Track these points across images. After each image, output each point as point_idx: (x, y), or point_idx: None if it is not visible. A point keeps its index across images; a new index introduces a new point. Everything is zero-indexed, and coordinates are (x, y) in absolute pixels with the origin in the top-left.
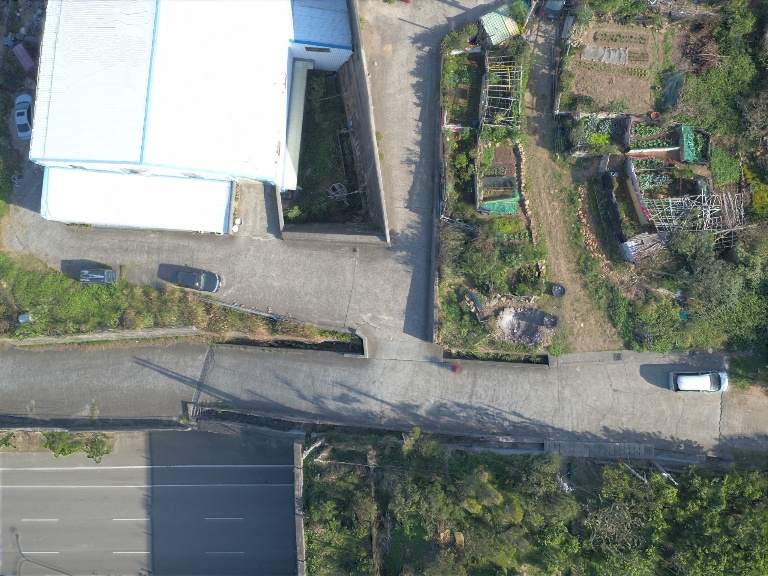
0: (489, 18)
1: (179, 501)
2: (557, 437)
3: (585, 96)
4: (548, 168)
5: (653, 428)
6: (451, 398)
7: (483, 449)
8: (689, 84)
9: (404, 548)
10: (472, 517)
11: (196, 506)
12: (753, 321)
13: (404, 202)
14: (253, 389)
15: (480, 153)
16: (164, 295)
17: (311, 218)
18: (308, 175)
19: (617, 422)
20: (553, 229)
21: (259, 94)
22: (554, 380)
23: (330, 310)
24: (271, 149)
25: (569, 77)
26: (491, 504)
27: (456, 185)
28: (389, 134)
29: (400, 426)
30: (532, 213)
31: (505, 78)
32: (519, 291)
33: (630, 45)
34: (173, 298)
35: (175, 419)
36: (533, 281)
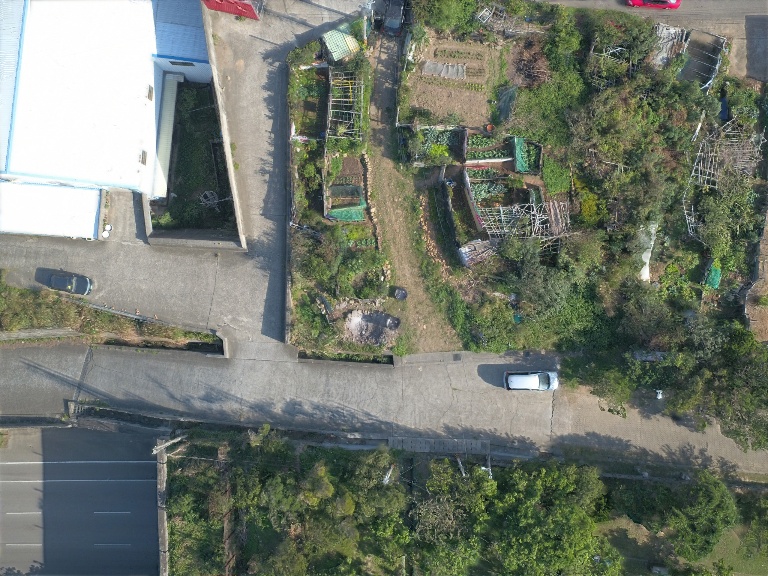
0: (331, 35)
1: (69, 496)
2: (401, 433)
3: (424, 109)
4: (393, 178)
5: (489, 425)
6: (305, 396)
7: (333, 445)
8: (521, 98)
9: (257, 539)
10: (314, 509)
11: (86, 500)
12: (581, 323)
13: (259, 209)
14: (127, 388)
15: (328, 163)
16: (39, 298)
17: (184, 224)
18: (179, 183)
19: (456, 419)
20: (397, 236)
21: (121, 106)
22: (398, 379)
23: (193, 312)
24: (133, 159)
25: (406, 92)
26: (325, 497)
27: (307, 193)
28: (243, 145)
29: (258, 423)
30: (378, 220)
31: (347, 92)
32: (364, 294)
33: (468, 61)
34: (47, 301)
35: (58, 416)
36: (378, 285)
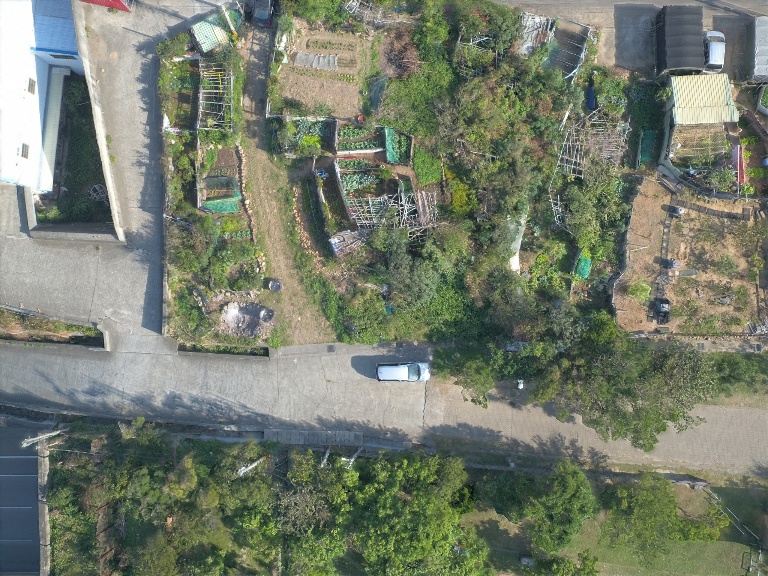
0: (199, 27)
1: None
2: (276, 426)
3: (294, 100)
4: (267, 169)
5: (362, 416)
6: (184, 389)
7: (210, 437)
8: (390, 89)
9: (135, 532)
10: (185, 502)
11: None
12: (451, 314)
13: (137, 202)
14: (16, 382)
15: (203, 155)
16: None
17: (73, 218)
18: (66, 177)
19: (330, 411)
20: (272, 227)
21: None
22: (274, 371)
23: (76, 305)
24: (11, 152)
25: (274, 83)
26: (190, 488)
27: (183, 186)
28: (119, 137)
29: None
30: (253, 212)
31: (217, 84)
32: (237, 286)
33: (340, 52)
34: None
35: None
36: (253, 277)
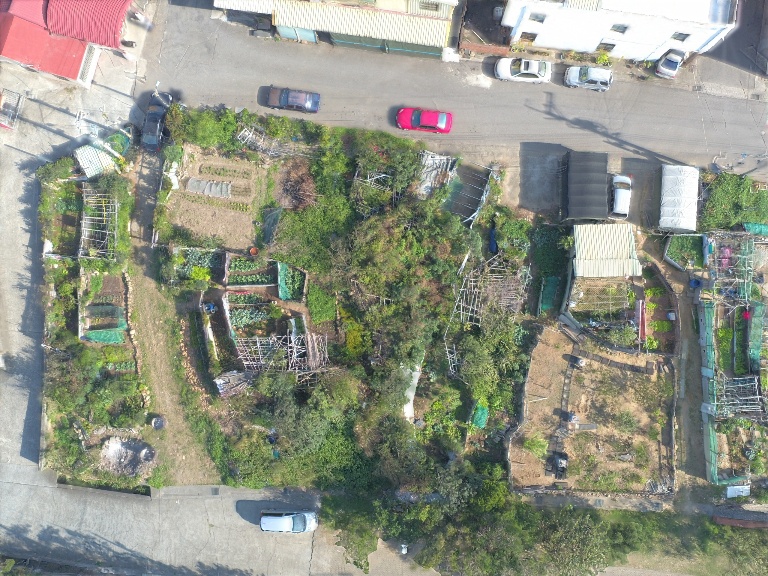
0: (83, 151)
1: None
2: (155, 571)
3: (183, 230)
4: (154, 298)
5: (246, 565)
6: (63, 525)
7: None
8: (283, 222)
9: None
10: None
11: None
12: (341, 462)
13: (18, 326)
14: None
15: (87, 281)
16: None
17: None
18: None
19: (212, 558)
20: (157, 360)
21: None
22: (155, 512)
23: None
24: None
25: (161, 213)
26: None
27: None
28: None
29: (13, 551)
30: (138, 343)
31: (100, 210)
32: (118, 423)
33: (234, 179)
34: None
35: None
36: (136, 412)
